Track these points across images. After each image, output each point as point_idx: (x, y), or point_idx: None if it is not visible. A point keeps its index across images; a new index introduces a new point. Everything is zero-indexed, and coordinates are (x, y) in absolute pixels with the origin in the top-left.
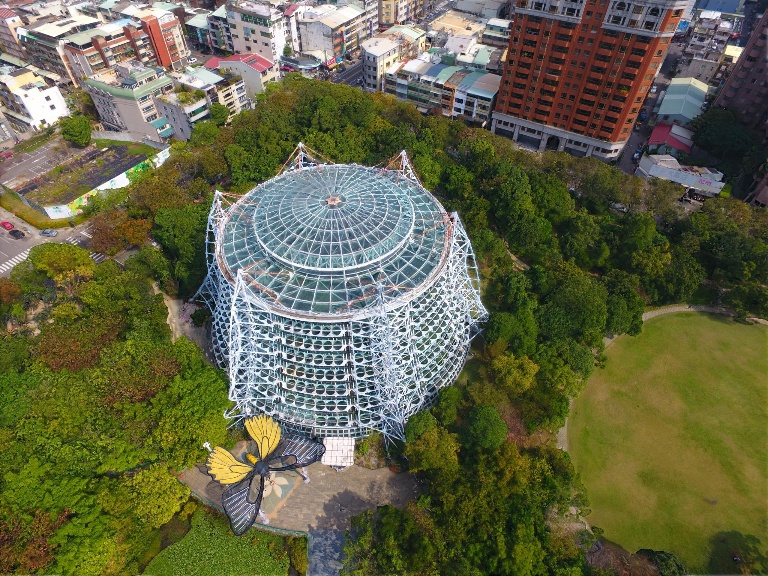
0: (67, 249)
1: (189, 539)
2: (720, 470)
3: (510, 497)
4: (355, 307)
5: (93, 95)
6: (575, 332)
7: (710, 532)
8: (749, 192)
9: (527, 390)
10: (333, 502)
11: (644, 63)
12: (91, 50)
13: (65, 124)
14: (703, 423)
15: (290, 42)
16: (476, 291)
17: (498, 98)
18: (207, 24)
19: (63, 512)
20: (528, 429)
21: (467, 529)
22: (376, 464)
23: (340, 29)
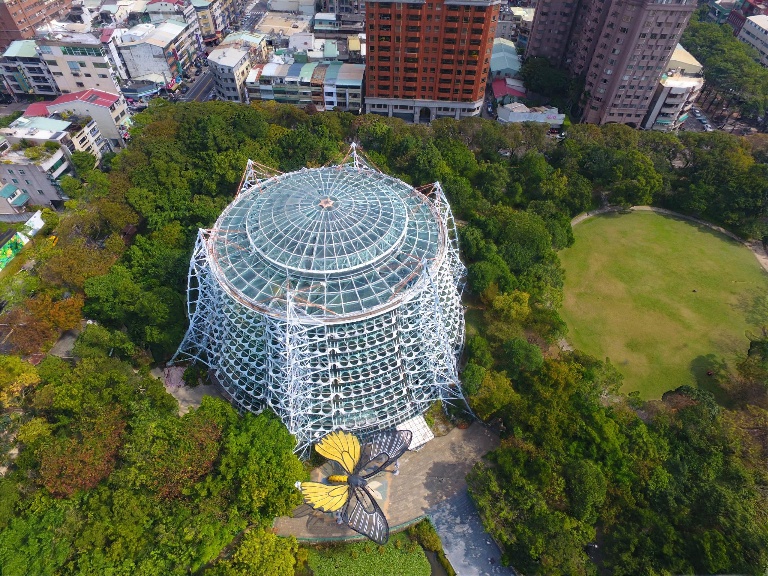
0: None
1: None
2: (669, 320)
3: (570, 399)
4: (398, 291)
5: None
6: (536, 258)
7: (687, 364)
8: (580, 117)
9: (528, 316)
10: (430, 478)
11: (485, 29)
12: None
13: None
14: (642, 292)
15: (115, 71)
16: (455, 250)
17: (367, 84)
18: None
19: None
20: (547, 345)
21: (559, 437)
22: (445, 430)
23: (170, 47)
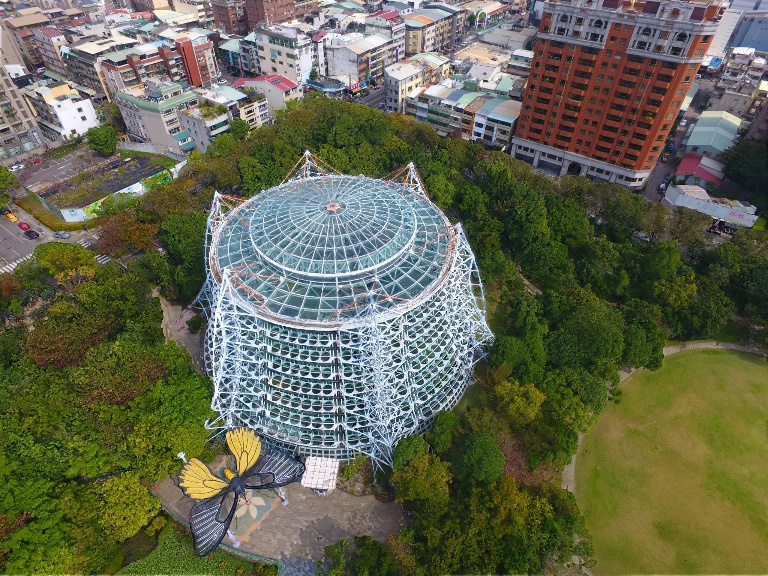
0: (72, 248)
1: (153, 557)
2: (750, 527)
3: (504, 538)
4: (345, 316)
5: (121, 107)
6: (587, 362)
7: None
8: None
9: (531, 421)
10: (311, 529)
11: (670, 89)
12: (126, 67)
13: (92, 133)
14: (731, 472)
15: (317, 67)
16: (481, 311)
17: (518, 123)
18: (239, 48)
19: (22, 515)
20: (530, 464)
21: (452, 571)
22: (361, 490)
23: (366, 55)
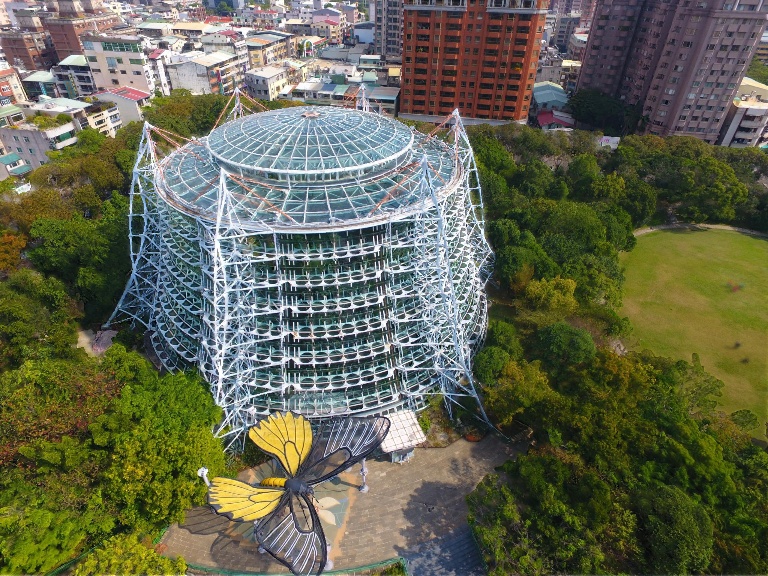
0: None
1: None
2: None
3: (638, 406)
4: (386, 210)
5: None
6: (586, 250)
7: None
8: None
9: None
10: (414, 504)
11: (530, 39)
12: None
13: None
14: (733, 308)
15: (159, 87)
16: None
17: (401, 99)
18: (53, 76)
19: None
20: (601, 342)
21: (623, 451)
22: (446, 439)
23: (215, 69)
